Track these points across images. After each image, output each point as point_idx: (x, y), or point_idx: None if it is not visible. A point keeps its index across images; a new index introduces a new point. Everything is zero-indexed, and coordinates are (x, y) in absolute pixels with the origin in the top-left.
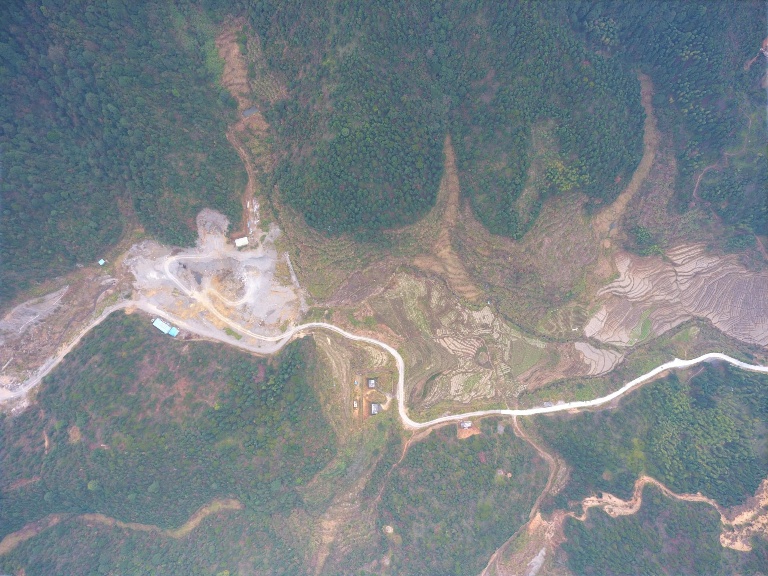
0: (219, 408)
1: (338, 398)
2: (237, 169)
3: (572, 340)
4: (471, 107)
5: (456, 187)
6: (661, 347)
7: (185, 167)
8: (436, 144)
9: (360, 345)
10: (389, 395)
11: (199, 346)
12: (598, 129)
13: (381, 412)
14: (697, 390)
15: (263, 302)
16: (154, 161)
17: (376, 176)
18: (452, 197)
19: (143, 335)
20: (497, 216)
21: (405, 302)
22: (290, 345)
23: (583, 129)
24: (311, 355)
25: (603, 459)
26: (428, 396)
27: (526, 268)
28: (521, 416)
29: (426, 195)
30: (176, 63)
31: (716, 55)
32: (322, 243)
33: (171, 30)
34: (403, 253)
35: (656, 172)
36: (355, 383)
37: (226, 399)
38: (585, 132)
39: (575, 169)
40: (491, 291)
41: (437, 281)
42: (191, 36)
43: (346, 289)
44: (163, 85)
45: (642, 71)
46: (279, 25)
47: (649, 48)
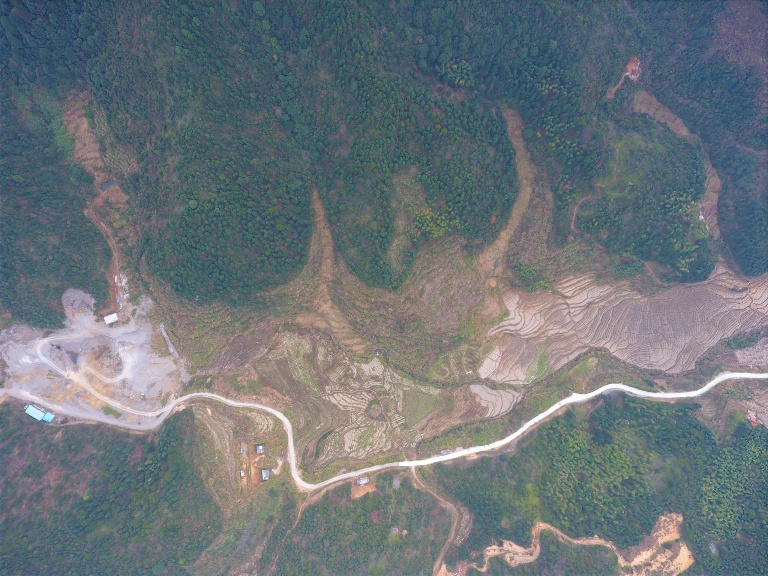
0: (88, 498)
1: (221, 470)
2: (97, 246)
3: (467, 383)
4: (331, 161)
5: (329, 241)
6: (559, 382)
7: (36, 253)
8: (300, 202)
9: (243, 412)
10: (280, 459)
11: (72, 431)
12: (459, 174)
13: (272, 477)
14: (595, 425)
15: (143, 376)
16: (3, 250)
17: (234, 243)
18: (327, 251)
19: (13, 425)
20: (369, 269)
21: (290, 361)
22: (168, 420)
23: (444, 176)
24: (188, 430)
25: (500, 507)
26: (321, 455)
27: (408, 317)
28: (420, 466)
29: (294, 255)
30: (19, 146)
31: (574, 88)
32: (196, 311)
33: (13, 112)
34: (283, 312)
35: (534, 207)
36: (241, 451)
37: (98, 486)
38: (446, 178)
39: (444, 215)
40: (378, 342)
41: (322, 337)
42: (36, 115)
43: (228, 354)
44: (2, 172)
45: (508, 106)
46: (119, 99)
47: (509, 84)
